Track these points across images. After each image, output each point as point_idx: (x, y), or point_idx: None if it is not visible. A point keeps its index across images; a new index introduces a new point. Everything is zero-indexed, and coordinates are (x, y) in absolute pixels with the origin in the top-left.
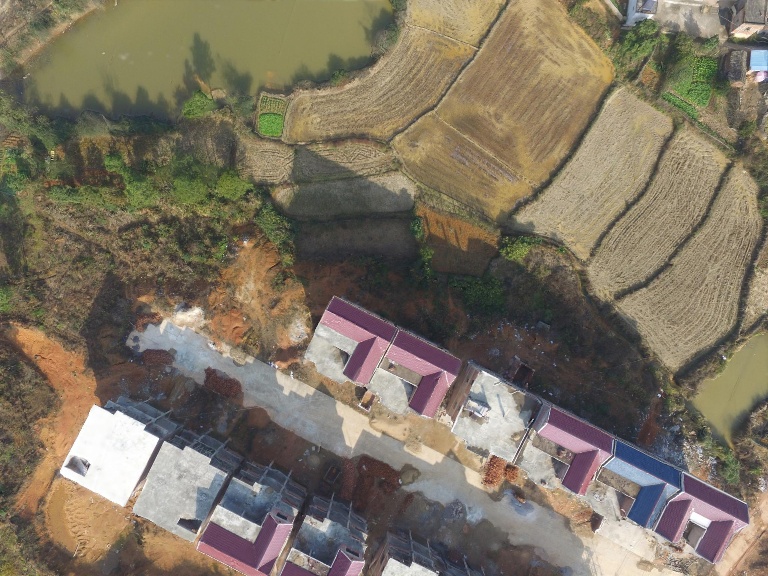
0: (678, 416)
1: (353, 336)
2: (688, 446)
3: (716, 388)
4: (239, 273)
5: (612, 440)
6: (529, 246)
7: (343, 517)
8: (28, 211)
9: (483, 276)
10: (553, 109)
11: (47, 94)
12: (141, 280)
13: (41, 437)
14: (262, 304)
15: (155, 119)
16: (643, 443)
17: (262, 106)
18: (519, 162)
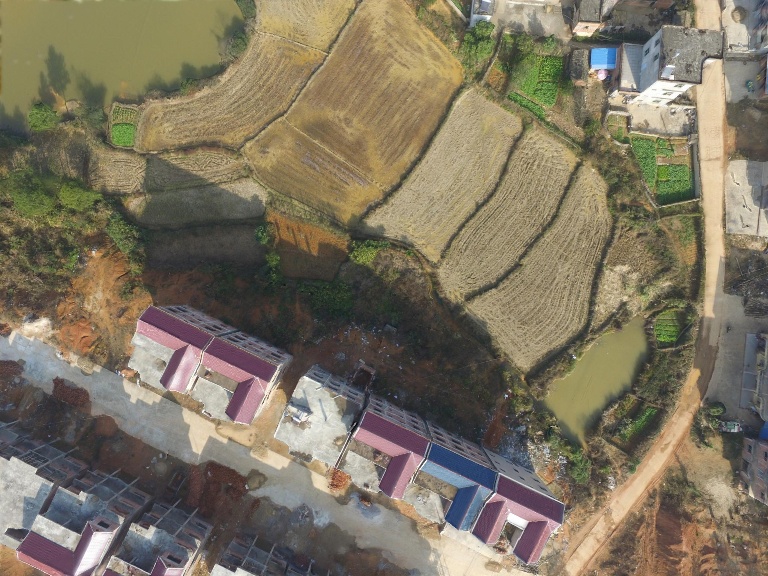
0: (525, 416)
1: (168, 344)
2: (532, 446)
3: (569, 387)
4: (88, 283)
5: (428, 443)
6: (375, 250)
7: (176, 524)
8: None
9: (333, 280)
10: (403, 112)
11: None
12: None
13: None
14: (110, 313)
15: (7, 132)
16: (488, 444)
17: (114, 116)
18: (370, 166)
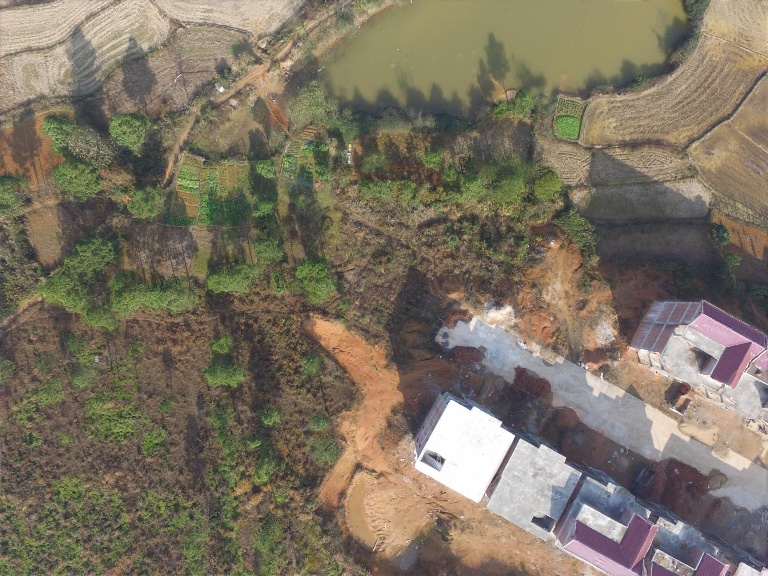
0: None
1: (724, 340)
2: None
3: None
4: (546, 273)
5: None
6: None
7: (681, 520)
8: (325, 203)
9: None
10: None
11: (341, 88)
12: (446, 277)
13: (342, 430)
14: (569, 305)
15: (458, 117)
16: None
17: (559, 108)
18: None
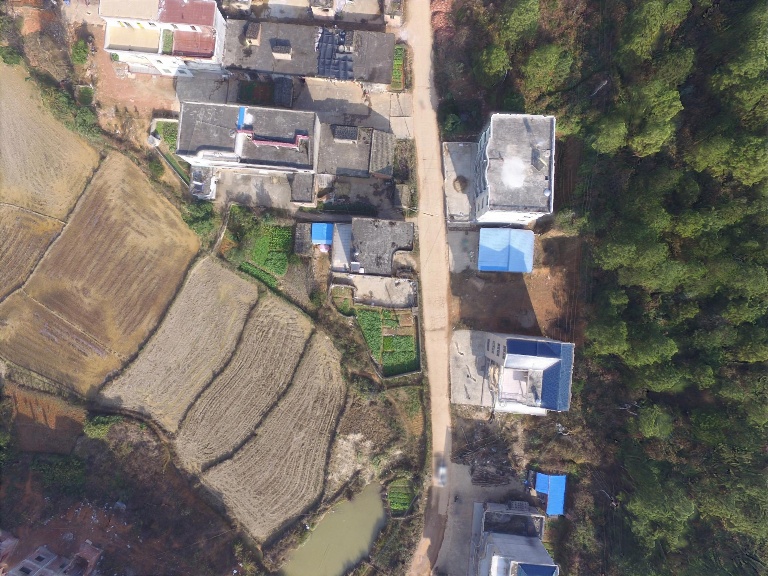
0: None
1: None
2: None
3: (306, 555)
4: None
5: None
6: (105, 426)
7: None
8: None
9: (70, 454)
10: (140, 281)
11: None
12: None
13: None
14: None
15: None
16: None
17: None
18: (108, 336)
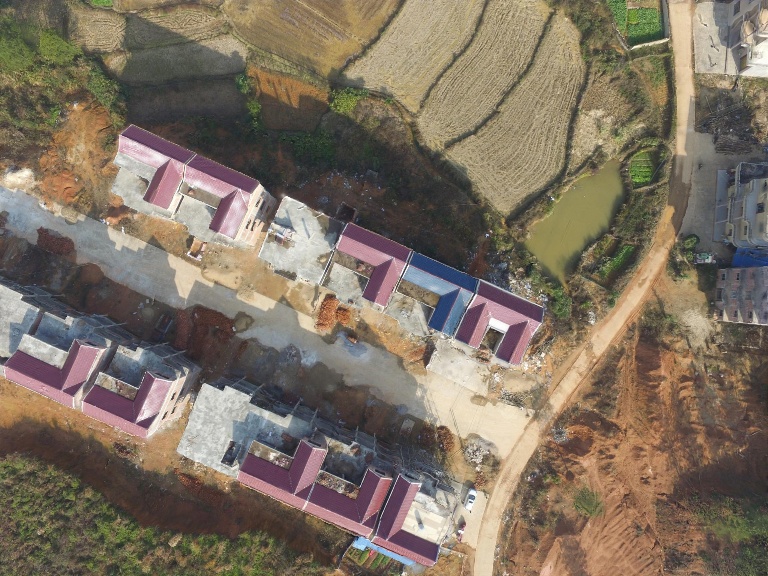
0: (506, 254)
1: (150, 161)
2: (514, 280)
3: (548, 230)
4: (70, 136)
5: (409, 251)
6: (355, 97)
7: (163, 352)
8: None
9: (315, 131)
10: None
11: None
12: None
13: None
14: (93, 165)
15: None
16: None
17: None
18: (348, 21)
